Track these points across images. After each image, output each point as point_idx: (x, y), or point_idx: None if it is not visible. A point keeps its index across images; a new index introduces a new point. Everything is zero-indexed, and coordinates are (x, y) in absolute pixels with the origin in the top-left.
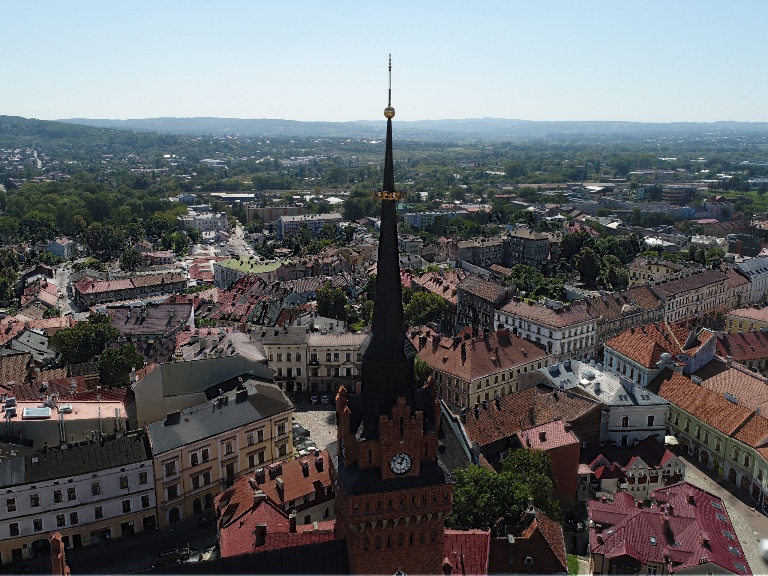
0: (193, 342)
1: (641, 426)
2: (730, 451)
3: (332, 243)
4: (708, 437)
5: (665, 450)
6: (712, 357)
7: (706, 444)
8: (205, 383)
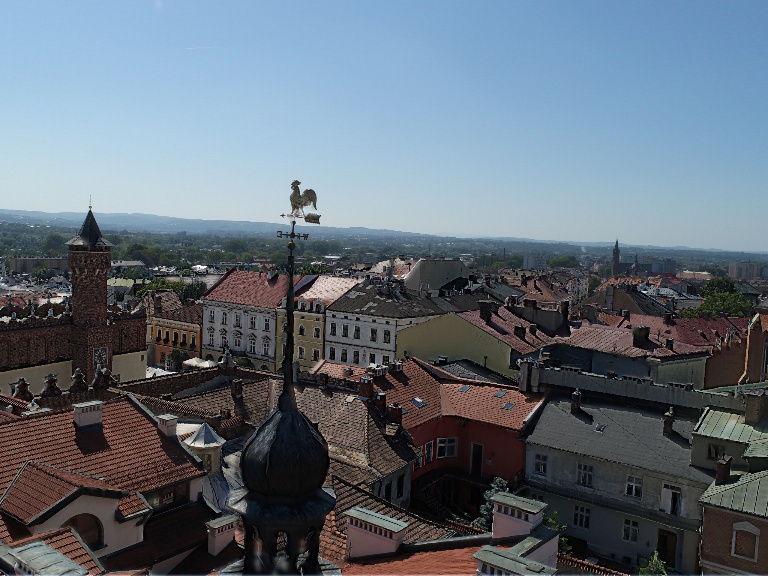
0: (367, 268)
1: None
2: None
3: (210, 268)
4: None
5: None
6: None
7: None
8: (440, 282)
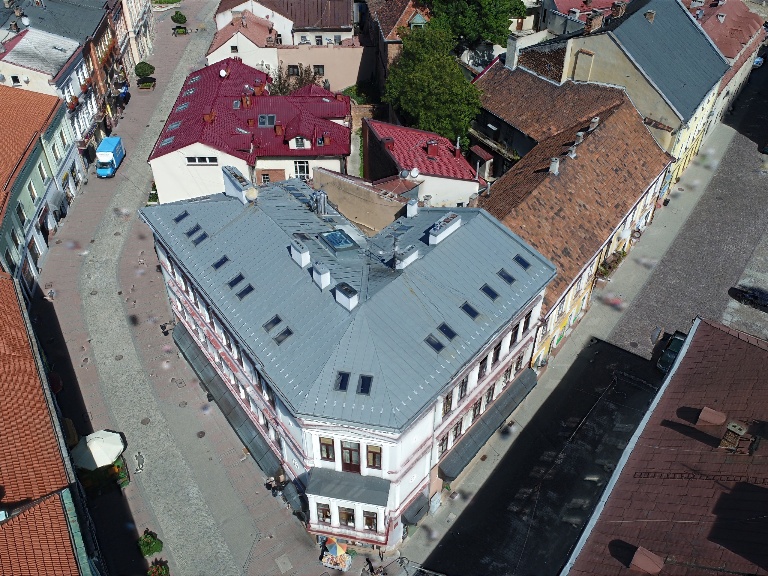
0: None
1: None
2: None
3: None
4: None
5: None
6: None
7: None
8: None
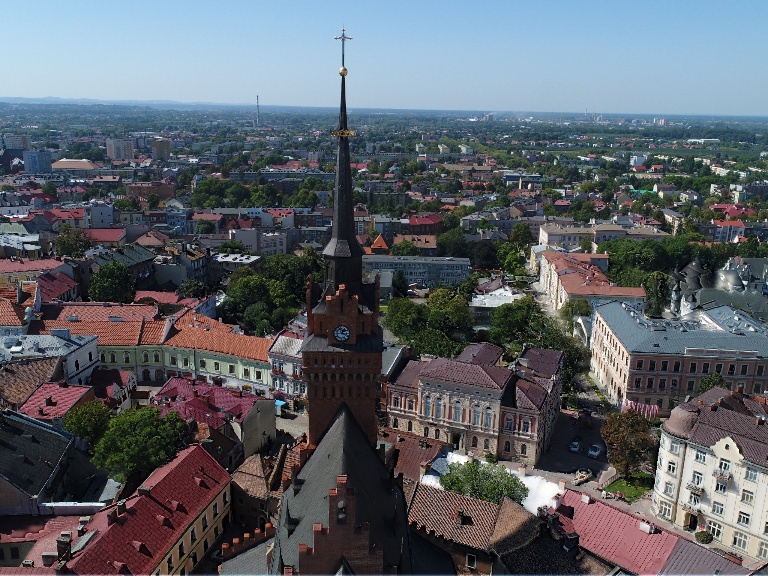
0: None
1: (86, 364)
2: (140, 357)
3: None
4: (115, 356)
5: (119, 372)
6: (40, 304)
7: (115, 363)
8: None
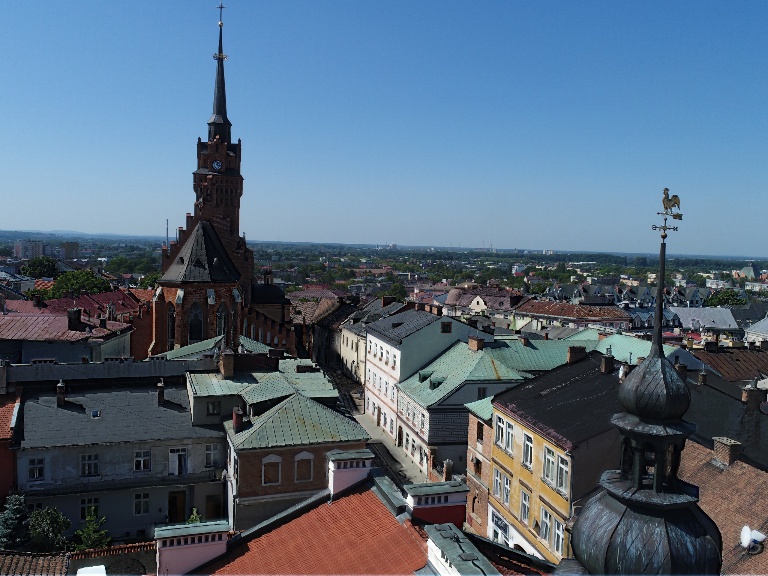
0: None
1: None
2: None
3: None
4: None
5: None
6: None
7: None
8: None
